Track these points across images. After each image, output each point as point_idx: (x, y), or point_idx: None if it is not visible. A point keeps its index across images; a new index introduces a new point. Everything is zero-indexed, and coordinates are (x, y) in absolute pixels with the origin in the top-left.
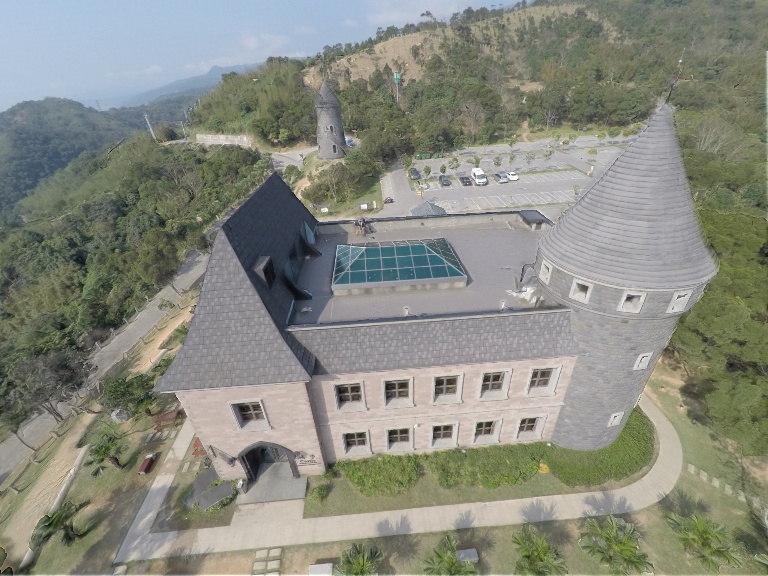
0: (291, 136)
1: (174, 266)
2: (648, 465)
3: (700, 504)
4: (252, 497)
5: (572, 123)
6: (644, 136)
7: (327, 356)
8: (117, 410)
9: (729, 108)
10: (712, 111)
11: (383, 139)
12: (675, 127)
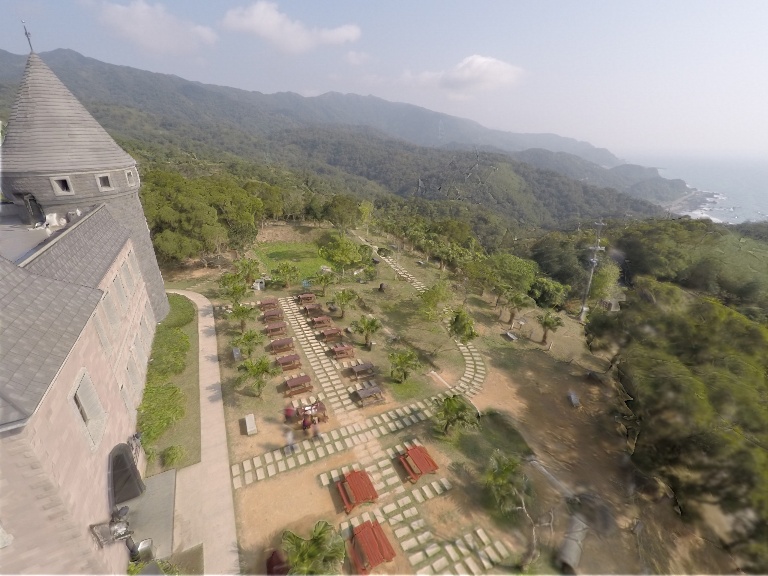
0: None
1: None
2: None
3: None
4: (164, 534)
5: None
6: (37, 72)
7: None
8: None
9: None
10: None
11: None
12: None
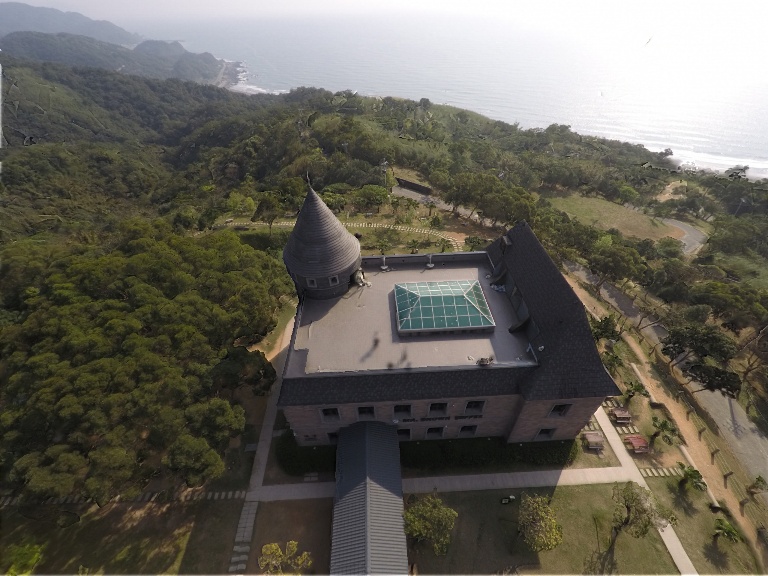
0: None
1: None
2: None
3: None
4: None
5: None
6: None
7: None
8: (614, 341)
9: None
10: None
11: None
12: None
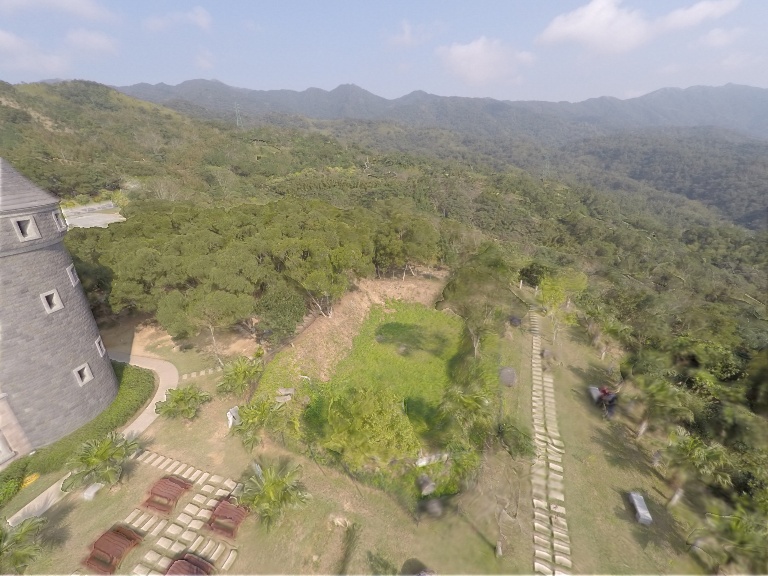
0: None
1: None
2: (151, 397)
3: None
4: None
5: None
6: None
7: None
8: None
9: None
10: None
11: None
12: None
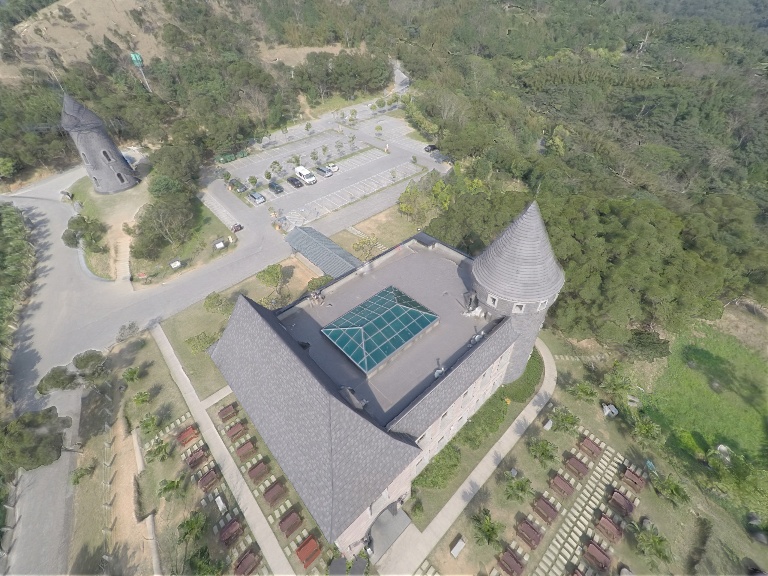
0: (19, 165)
1: (63, 427)
2: (543, 367)
3: (568, 373)
4: (380, 551)
5: (340, 93)
6: (528, 219)
7: (412, 428)
8: None
9: (438, 67)
10: (434, 76)
11: (187, 156)
12: None
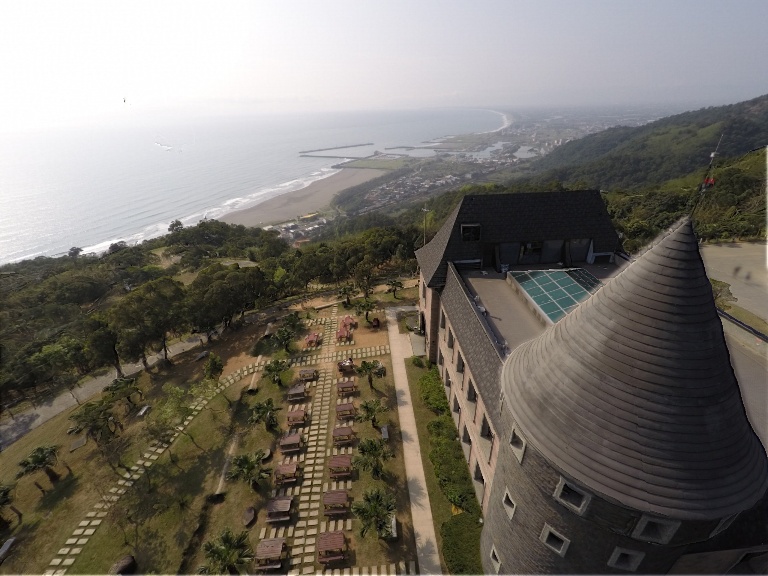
0: None
1: None
2: None
3: None
4: (413, 336)
5: None
6: None
7: None
8: None
9: None
10: None
11: None
12: (664, 255)
